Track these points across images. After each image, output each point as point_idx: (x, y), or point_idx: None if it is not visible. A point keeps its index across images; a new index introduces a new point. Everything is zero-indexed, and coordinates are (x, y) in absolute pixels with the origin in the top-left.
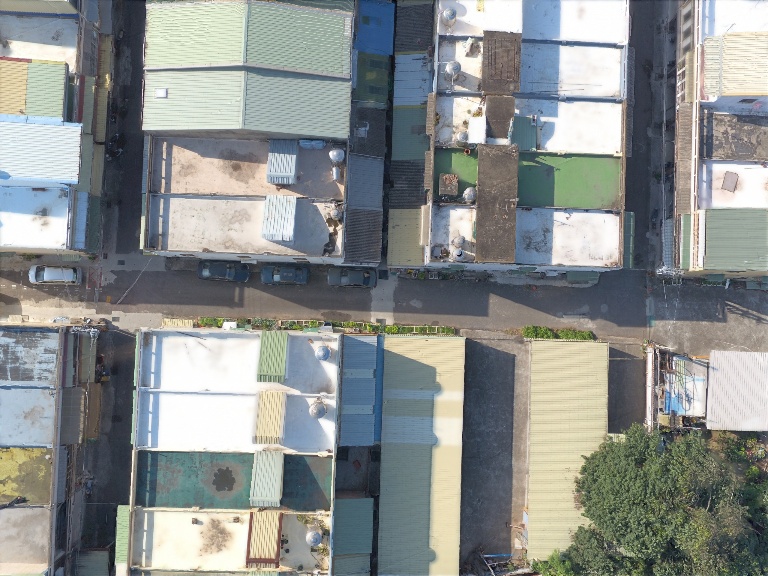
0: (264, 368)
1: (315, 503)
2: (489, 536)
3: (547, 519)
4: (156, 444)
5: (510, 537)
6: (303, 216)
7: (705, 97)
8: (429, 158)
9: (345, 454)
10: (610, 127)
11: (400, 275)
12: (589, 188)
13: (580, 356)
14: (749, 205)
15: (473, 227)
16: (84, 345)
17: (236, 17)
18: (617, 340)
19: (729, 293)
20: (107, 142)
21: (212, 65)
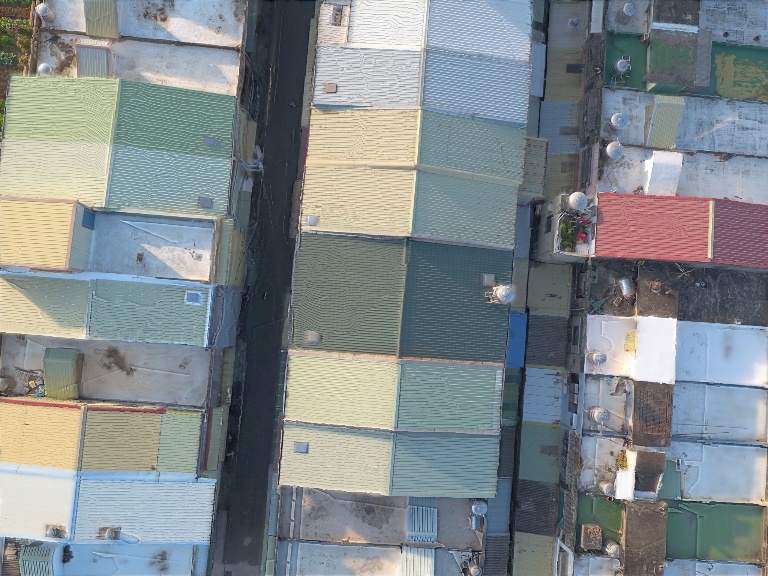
0: None
1: None
2: None
3: None
4: None
5: None
6: (438, 565)
7: None
8: (569, 501)
9: None
10: (755, 472)
11: None
12: (732, 537)
13: None
14: None
15: None
16: None
17: (388, 379)
18: None
19: None
20: None
21: (360, 426)
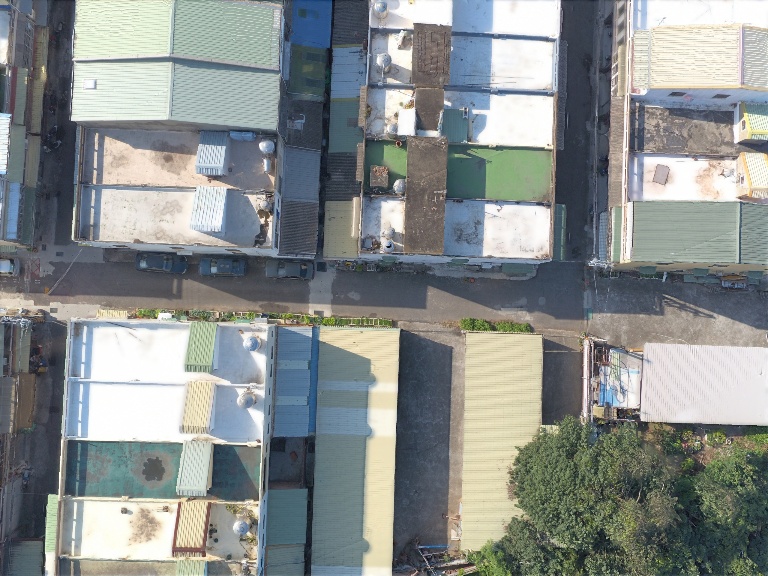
0: (192, 358)
1: (244, 493)
2: (425, 527)
3: (480, 510)
4: (86, 434)
5: (446, 528)
6: (234, 207)
7: (637, 90)
8: (361, 150)
9: (282, 445)
10: (542, 120)
11: (338, 267)
12: (520, 180)
13: (514, 348)
14: (680, 198)
15: (404, 219)
16: (18, 335)
17: (163, 8)
18: (554, 333)
19: (666, 286)
20: (45, 134)
21: (139, 56)
